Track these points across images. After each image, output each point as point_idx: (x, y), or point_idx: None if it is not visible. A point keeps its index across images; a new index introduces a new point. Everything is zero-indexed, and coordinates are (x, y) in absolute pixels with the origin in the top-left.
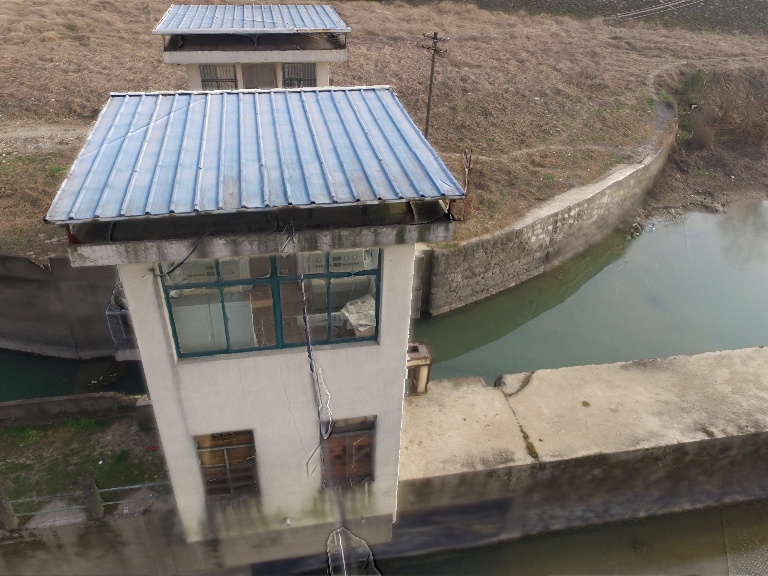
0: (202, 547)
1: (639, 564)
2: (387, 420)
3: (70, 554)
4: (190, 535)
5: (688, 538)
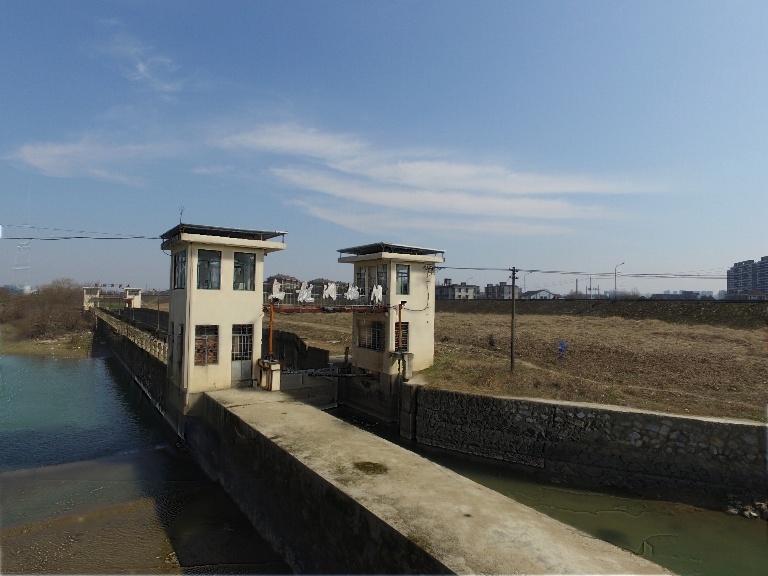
0: None
1: (215, 528)
2: None
3: None
4: None
5: (245, 546)
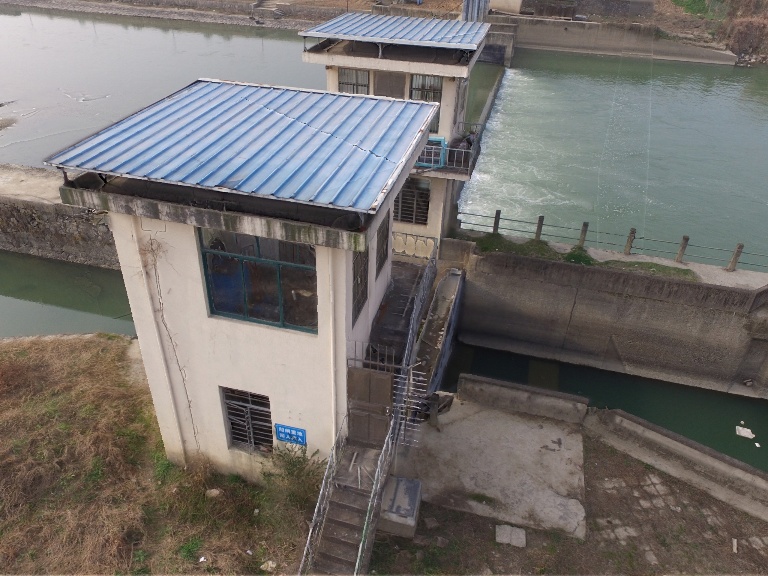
0: None
1: None
2: None
3: None
4: None
5: None
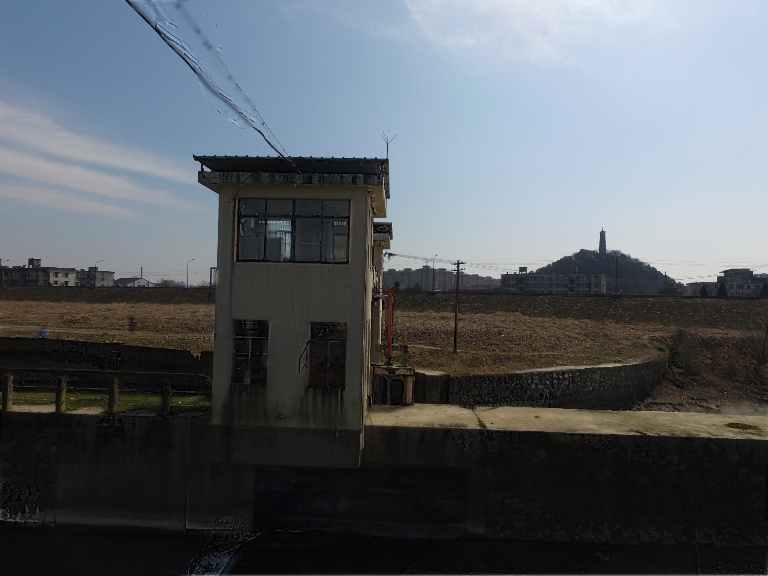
0: (220, 434)
1: (601, 565)
2: (353, 329)
3: (136, 448)
4: (214, 417)
5: (656, 557)
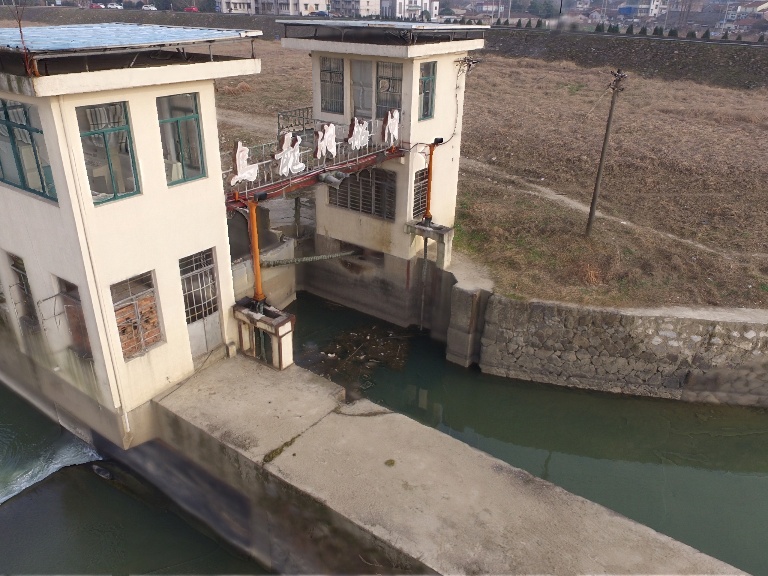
0: None
1: None
2: (84, 296)
3: None
4: None
5: None
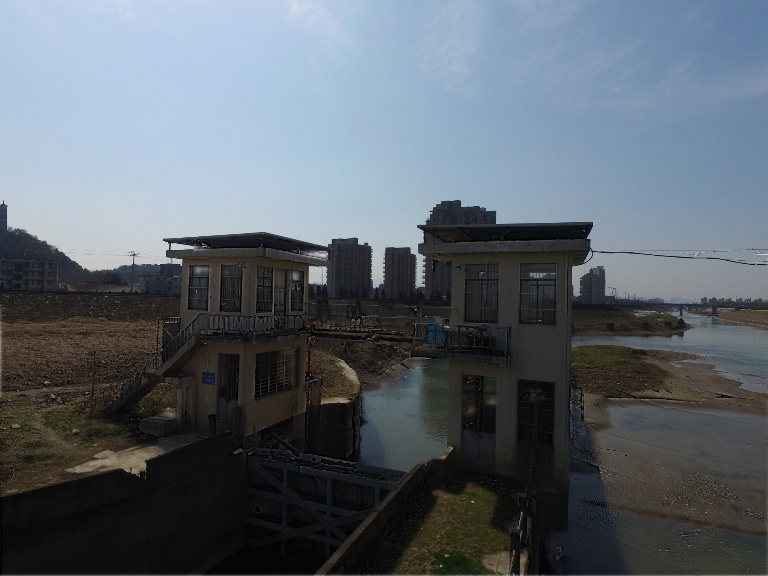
0: None
1: (571, 473)
2: None
3: None
4: None
5: None
